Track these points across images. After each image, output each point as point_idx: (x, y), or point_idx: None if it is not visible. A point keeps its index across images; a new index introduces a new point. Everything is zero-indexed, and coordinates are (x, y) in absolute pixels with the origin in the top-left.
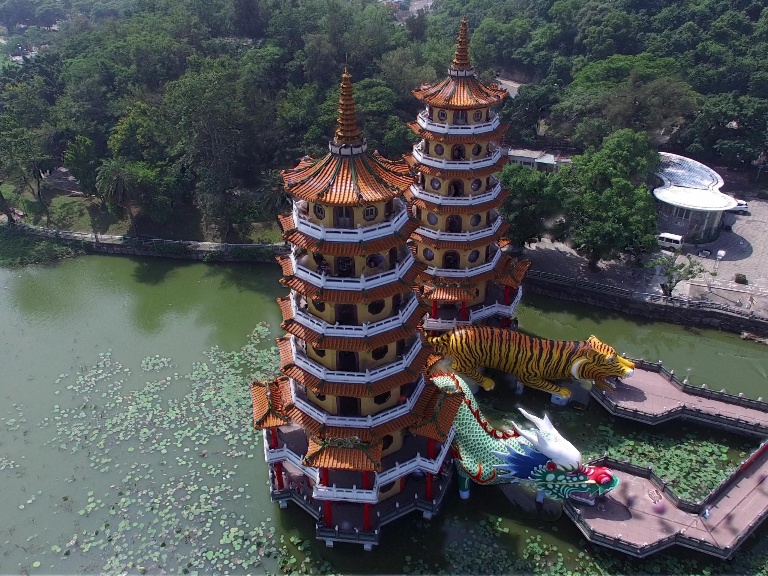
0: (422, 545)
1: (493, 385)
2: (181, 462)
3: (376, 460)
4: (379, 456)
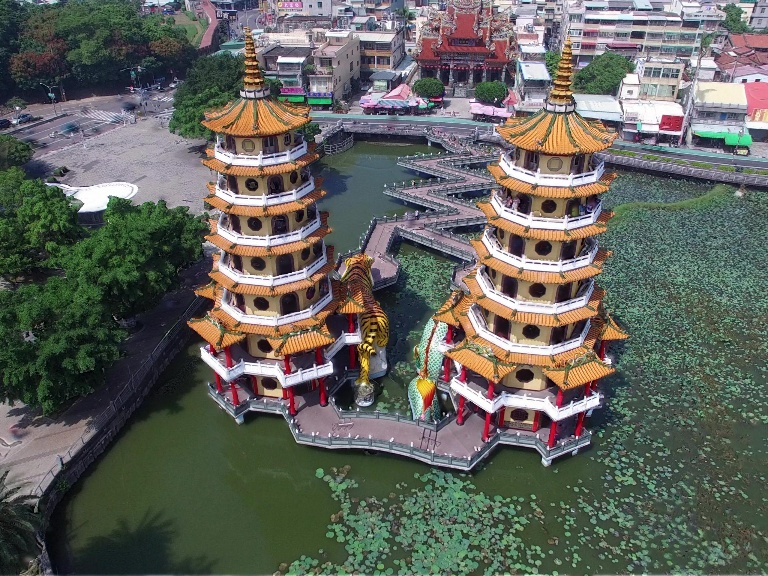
0: None
1: None
2: (578, 559)
3: None
4: None
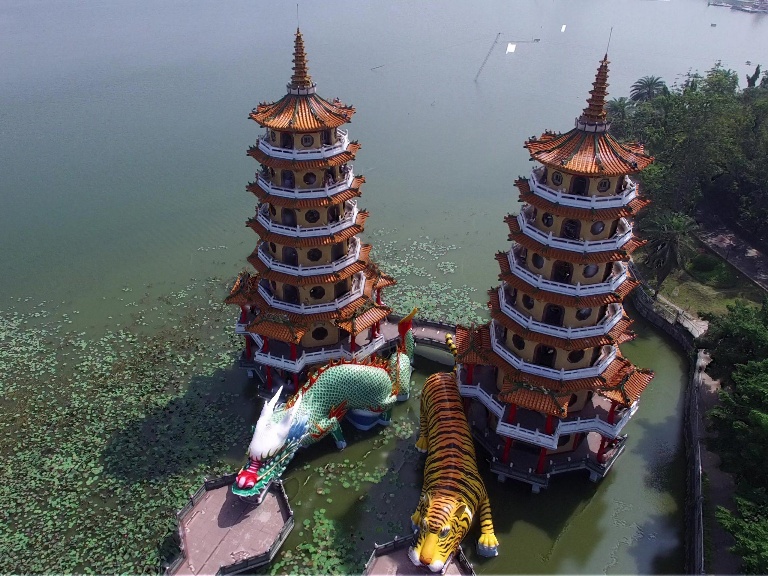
0: (247, 402)
1: (422, 449)
2: None
3: (231, 296)
4: (238, 301)
